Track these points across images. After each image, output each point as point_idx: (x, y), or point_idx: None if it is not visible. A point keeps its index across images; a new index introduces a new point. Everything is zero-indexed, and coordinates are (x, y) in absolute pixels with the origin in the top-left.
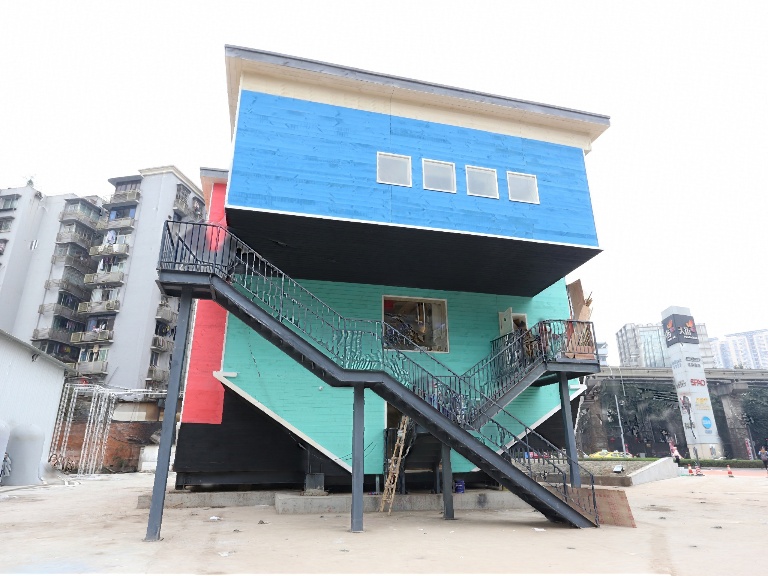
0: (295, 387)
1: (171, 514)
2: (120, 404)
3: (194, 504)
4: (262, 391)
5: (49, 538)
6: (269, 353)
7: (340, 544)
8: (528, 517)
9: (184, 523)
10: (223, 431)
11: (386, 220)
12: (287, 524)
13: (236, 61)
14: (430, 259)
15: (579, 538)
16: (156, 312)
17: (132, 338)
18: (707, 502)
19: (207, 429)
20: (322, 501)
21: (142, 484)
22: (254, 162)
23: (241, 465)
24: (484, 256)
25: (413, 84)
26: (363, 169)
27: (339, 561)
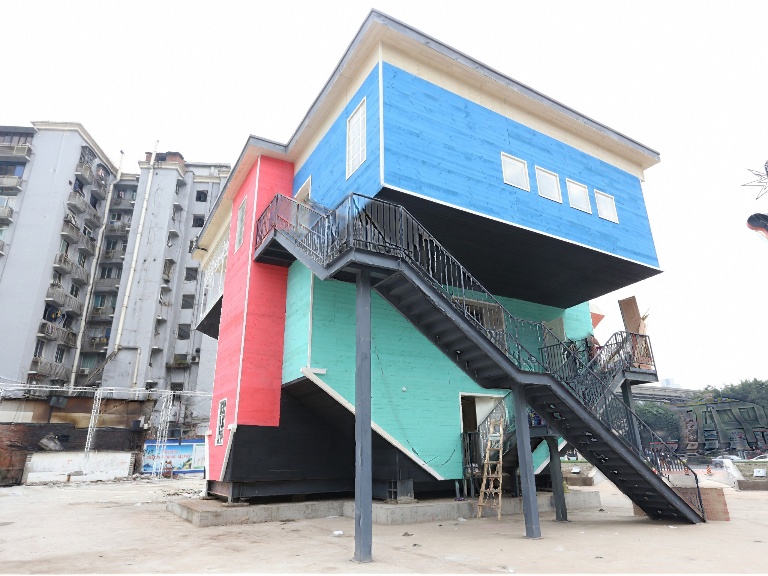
0: (381, 387)
1: (261, 531)
2: (5, 402)
3: (261, 519)
4: (350, 391)
5: (225, 568)
6: (354, 349)
7: (569, 551)
8: (616, 516)
9: (322, 540)
10: (281, 434)
11: (515, 221)
12: (437, 535)
13: (381, 29)
14: (520, 264)
15: (726, 532)
16: (46, 293)
17: (13, 322)
18: None
19: (264, 432)
20: (426, 509)
21: (80, 499)
22: (402, 142)
23: (301, 473)
24: (567, 267)
25: (528, 91)
26: (492, 167)
27: (635, 568)
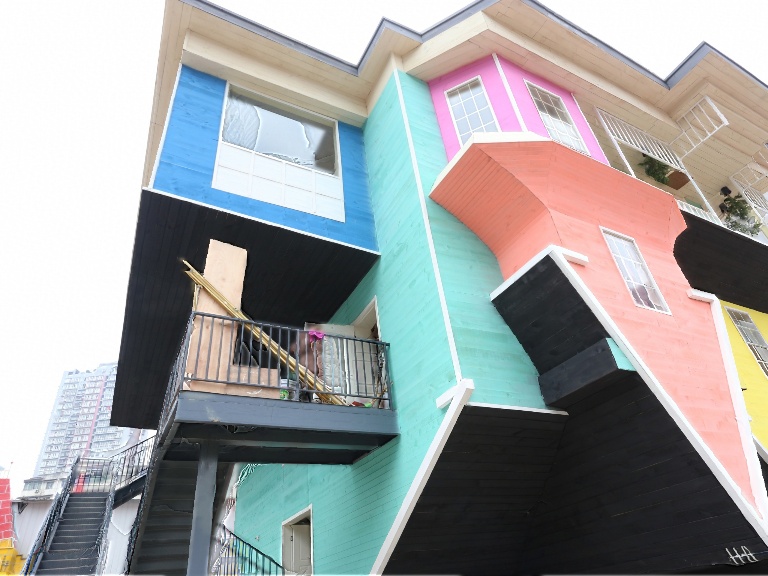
0: None
1: None
2: None
3: None
4: None
5: None
6: None
7: None
8: None
9: None
10: None
11: None
12: None
13: None
14: None
15: None
16: None
17: None
18: None
19: None
20: None
21: None
22: None
23: None
24: (189, 314)
25: None
26: None
27: None
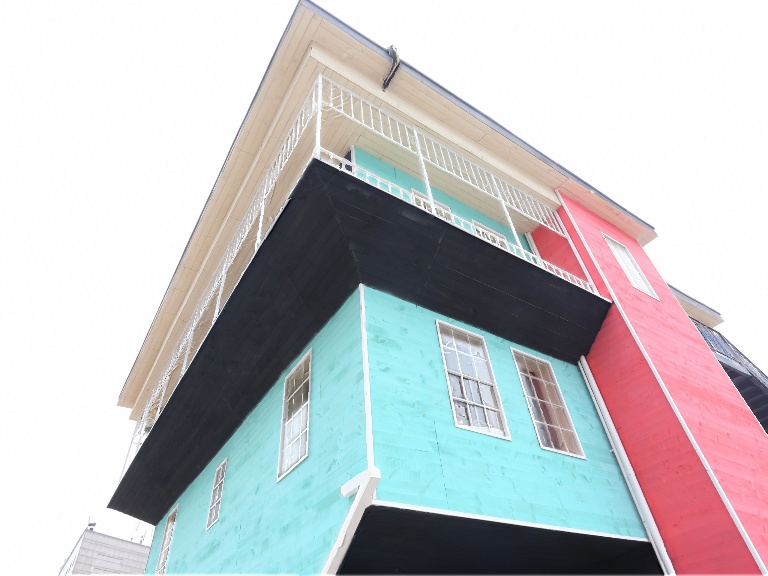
0: None
1: None
2: None
3: None
4: None
5: None
6: None
7: None
8: None
9: None
10: None
11: None
12: None
13: None
14: None
15: None
16: None
17: None
18: None
19: None
20: None
21: None
22: None
23: None
24: None
25: None
26: None
27: None
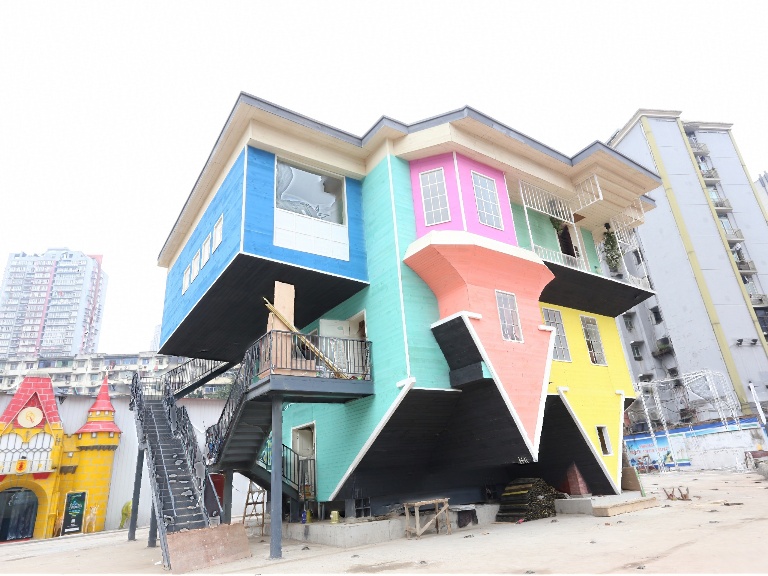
0: None
1: None
2: None
3: None
4: None
5: None
6: None
7: None
8: None
9: None
10: None
11: None
12: None
13: (161, 264)
14: (241, 320)
15: None
16: None
17: None
18: (545, 573)
19: None
20: None
21: None
22: None
23: None
24: (241, 303)
25: None
26: None
27: None
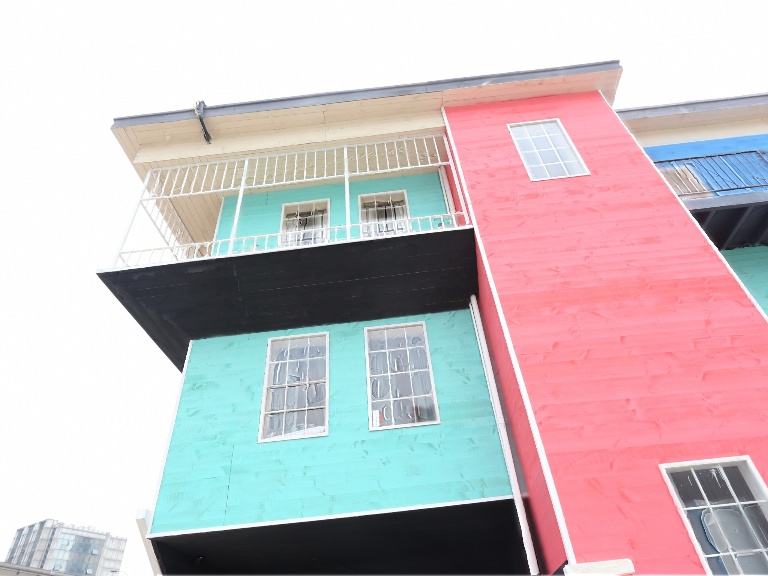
0: None
1: None
2: None
3: None
4: None
5: None
6: None
7: None
8: None
9: None
10: None
11: None
12: None
13: None
14: None
15: None
16: None
17: None
18: None
19: None
20: None
21: None
22: None
23: None
24: None
25: None
26: None
27: None
